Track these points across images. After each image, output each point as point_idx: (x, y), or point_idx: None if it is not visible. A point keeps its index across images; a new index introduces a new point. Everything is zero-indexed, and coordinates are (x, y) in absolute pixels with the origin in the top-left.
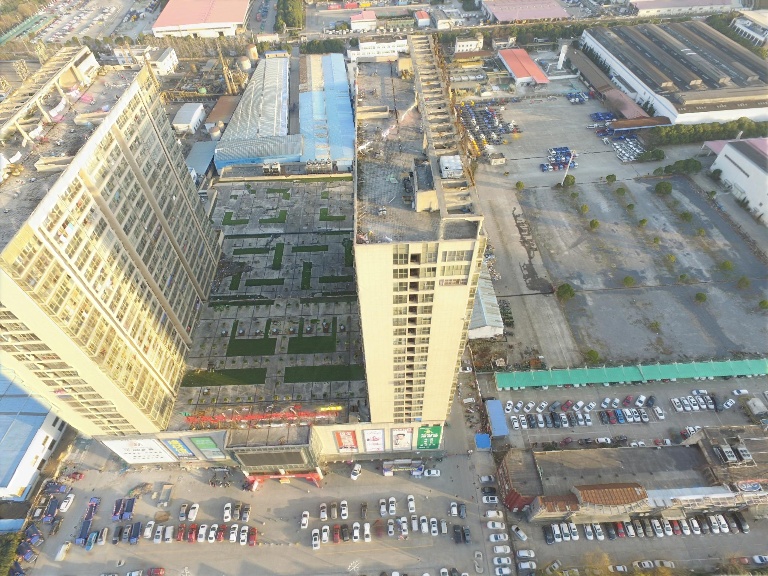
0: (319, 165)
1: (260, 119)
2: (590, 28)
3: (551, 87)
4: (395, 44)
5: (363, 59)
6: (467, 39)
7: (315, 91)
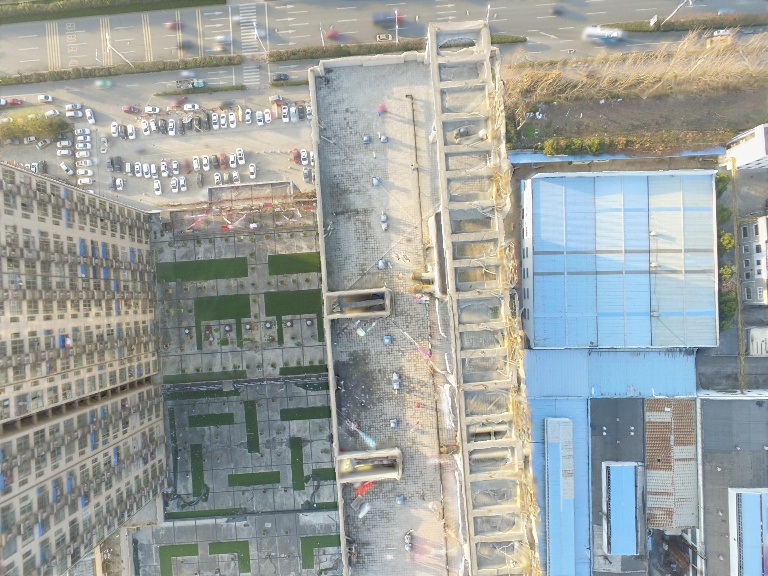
0: None
1: None
2: None
3: None
4: None
5: None
6: None
7: None
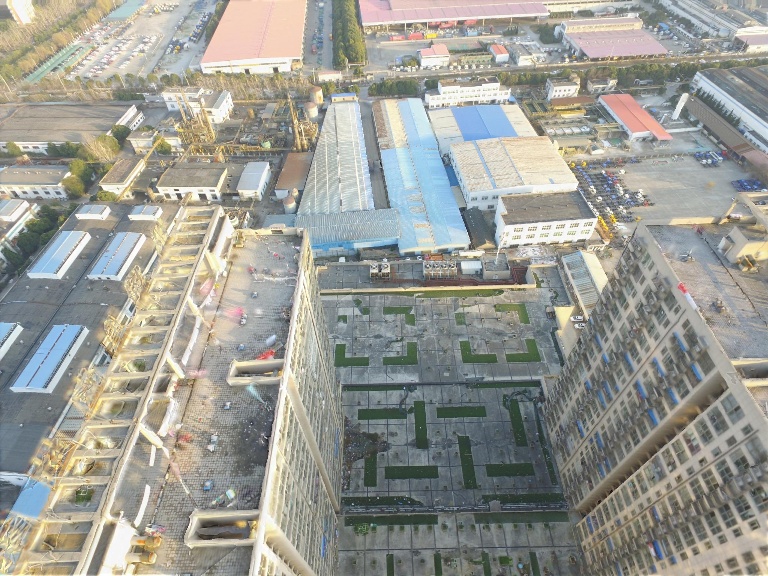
0: (441, 269)
1: (341, 186)
2: (705, 70)
3: (672, 143)
4: (481, 88)
5: (650, 221)
6: (564, 83)
7: (399, 148)
